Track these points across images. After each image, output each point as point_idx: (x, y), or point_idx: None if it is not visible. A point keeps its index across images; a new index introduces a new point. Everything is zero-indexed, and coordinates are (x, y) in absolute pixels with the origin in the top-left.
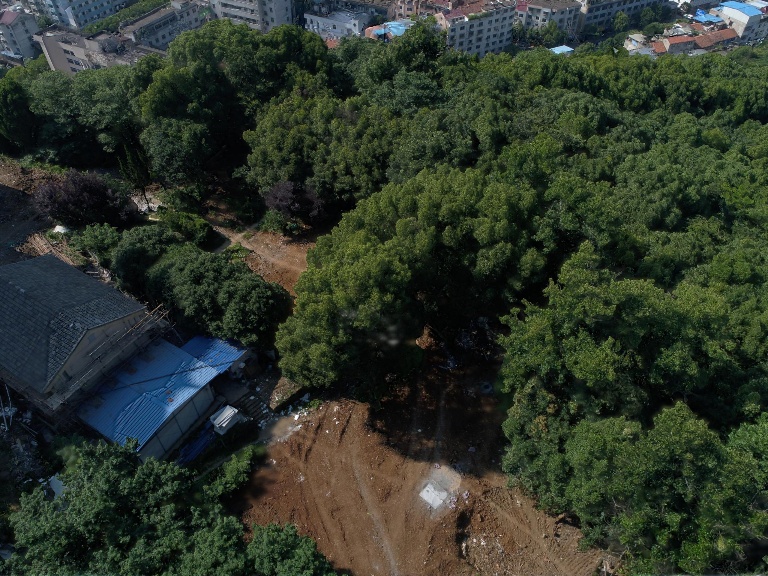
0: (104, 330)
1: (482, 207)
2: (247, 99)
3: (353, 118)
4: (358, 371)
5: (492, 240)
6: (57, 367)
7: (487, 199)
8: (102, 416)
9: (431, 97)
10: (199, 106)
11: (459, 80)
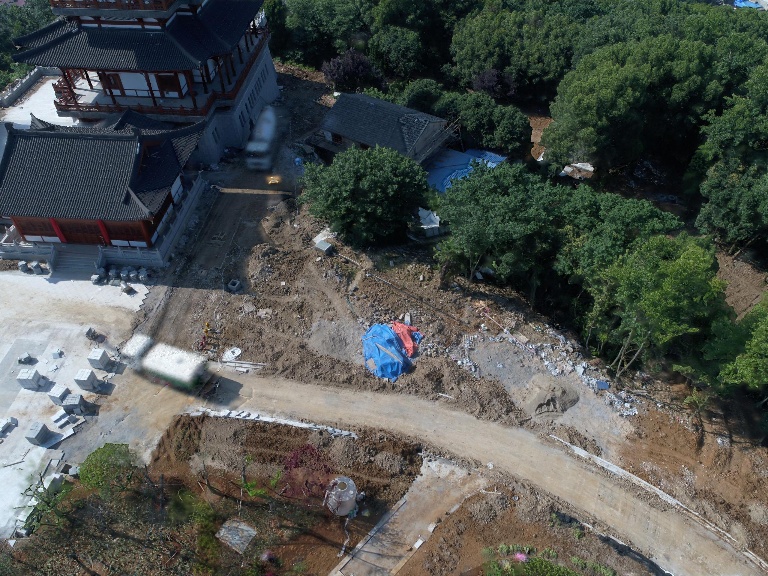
0: (433, 126)
1: (680, 53)
2: (447, 15)
3: (537, 25)
4: (605, 152)
5: (686, 75)
6: (412, 143)
7: (683, 47)
8: (432, 182)
9: (596, 10)
10: (415, 18)
11: (607, 4)
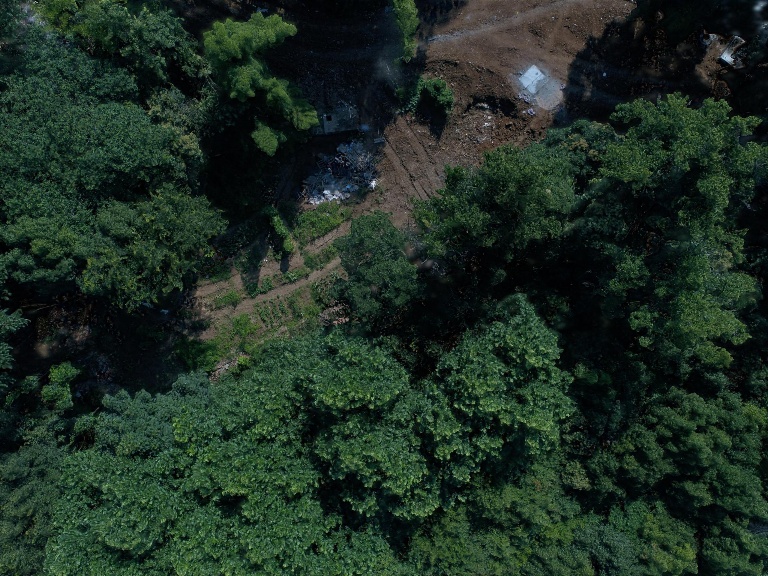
0: None
1: None
2: None
3: None
4: None
5: None
6: None
7: None
8: None
9: None
10: None
11: None
